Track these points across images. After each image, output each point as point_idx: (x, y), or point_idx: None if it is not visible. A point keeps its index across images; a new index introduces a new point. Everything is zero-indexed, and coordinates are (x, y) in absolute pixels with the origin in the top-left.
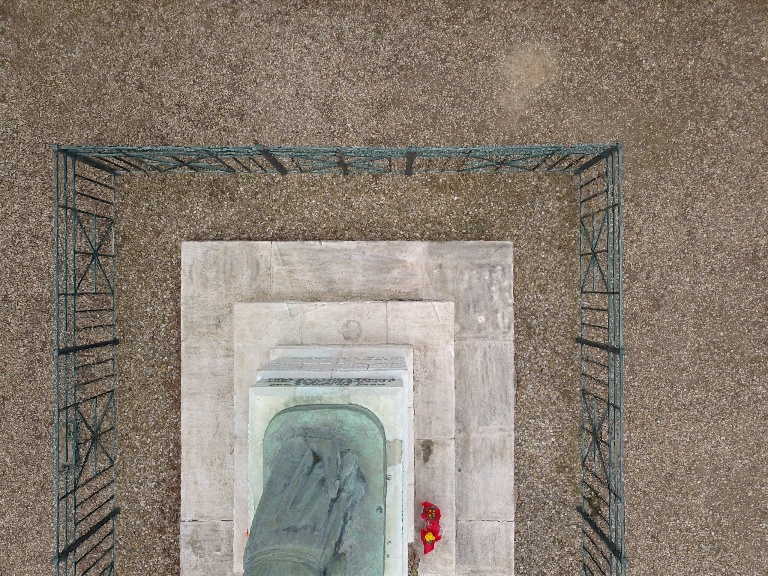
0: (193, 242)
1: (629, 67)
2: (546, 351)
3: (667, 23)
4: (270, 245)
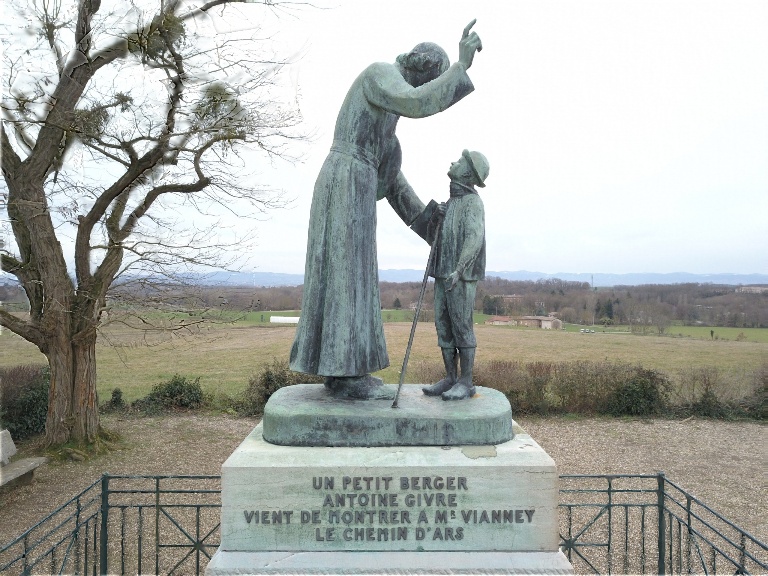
0: None
1: (21, 571)
2: None
3: (2, 553)
4: None
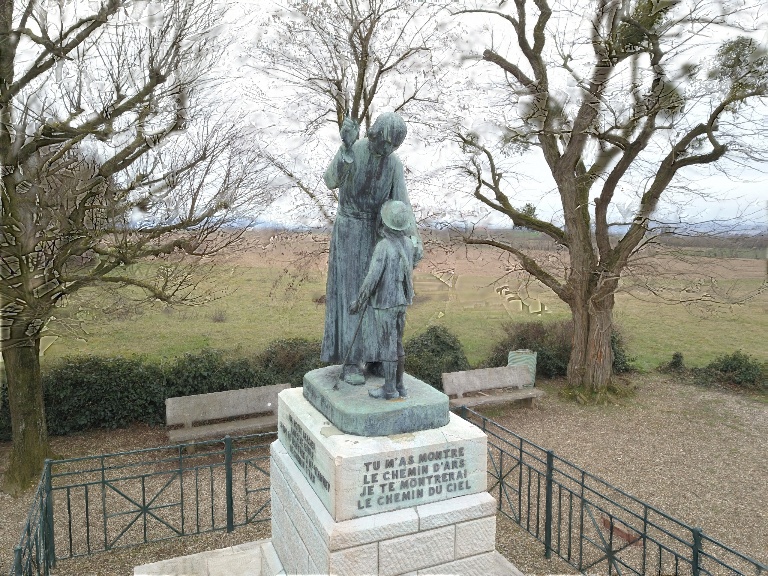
0: (147, 564)
1: None
2: (528, 568)
3: None
4: (231, 548)
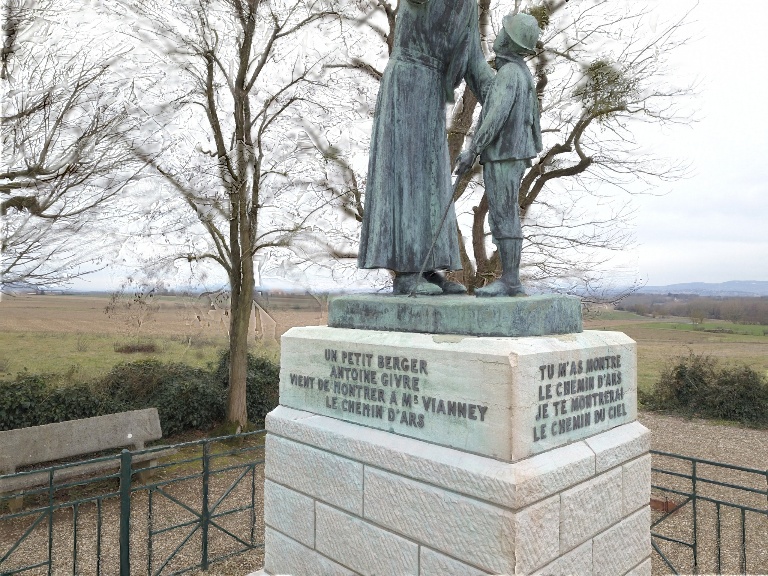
0: None
1: None
2: None
3: None
4: None
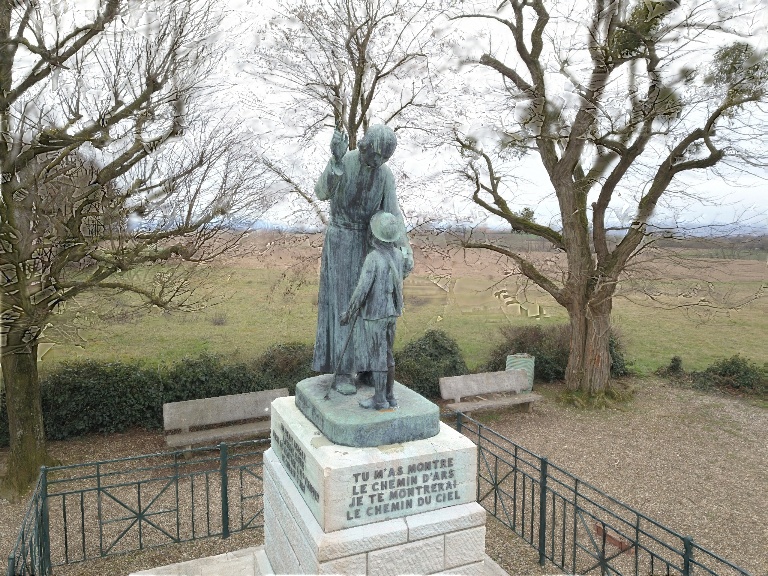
0: (142, 571)
1: None
2: (522, 575)
3: None
4: (225, 555)
